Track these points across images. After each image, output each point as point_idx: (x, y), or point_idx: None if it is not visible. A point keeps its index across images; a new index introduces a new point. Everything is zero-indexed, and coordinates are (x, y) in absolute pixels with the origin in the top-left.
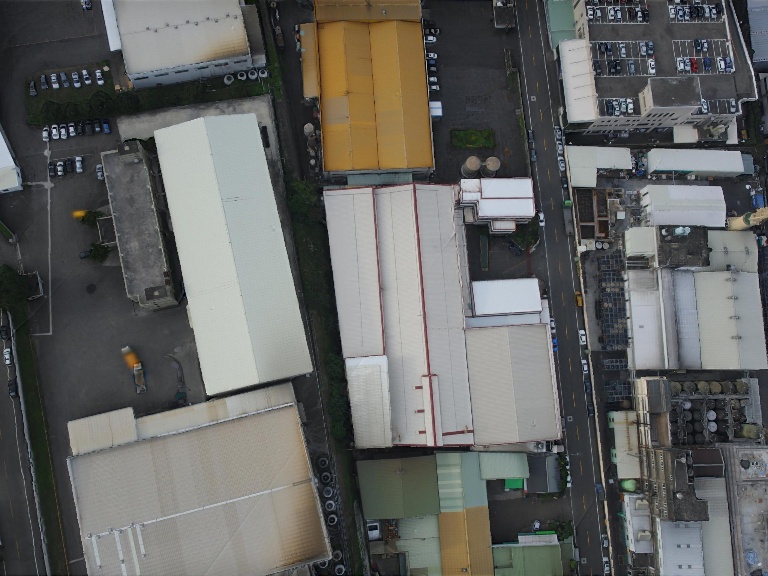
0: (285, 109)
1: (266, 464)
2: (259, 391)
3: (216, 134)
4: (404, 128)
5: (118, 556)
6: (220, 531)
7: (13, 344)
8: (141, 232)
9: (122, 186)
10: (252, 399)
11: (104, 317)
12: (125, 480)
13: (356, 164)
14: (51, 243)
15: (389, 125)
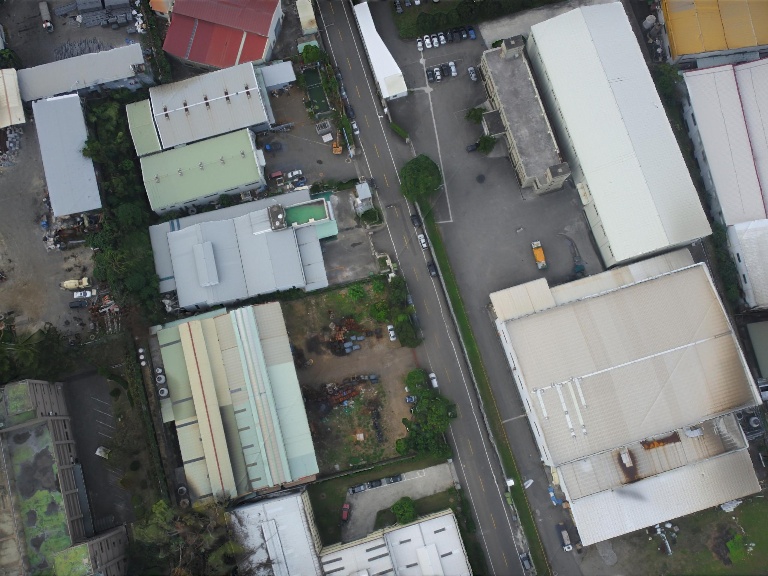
0: (629, 3)
1: (685, 320)
2: (659, 257)
3: (593, 22)
4: (749, 8)
5: (562, 408)
6: (652, 382)
7: (424, 231)
8: (529, 120)
9: (505, 80)
10: (653, 265)
11: (496, 203)
12: (556, 340)
13: (707, 46)
14: (439, 141)
15: (733, 7)
